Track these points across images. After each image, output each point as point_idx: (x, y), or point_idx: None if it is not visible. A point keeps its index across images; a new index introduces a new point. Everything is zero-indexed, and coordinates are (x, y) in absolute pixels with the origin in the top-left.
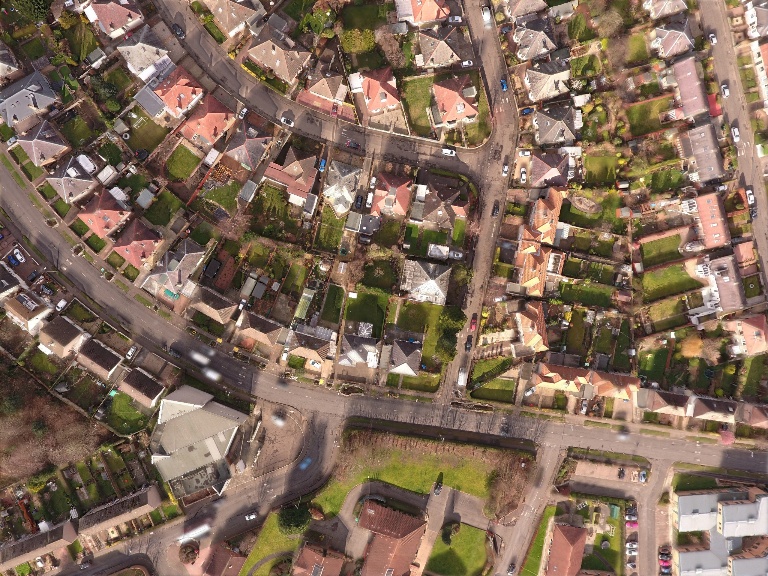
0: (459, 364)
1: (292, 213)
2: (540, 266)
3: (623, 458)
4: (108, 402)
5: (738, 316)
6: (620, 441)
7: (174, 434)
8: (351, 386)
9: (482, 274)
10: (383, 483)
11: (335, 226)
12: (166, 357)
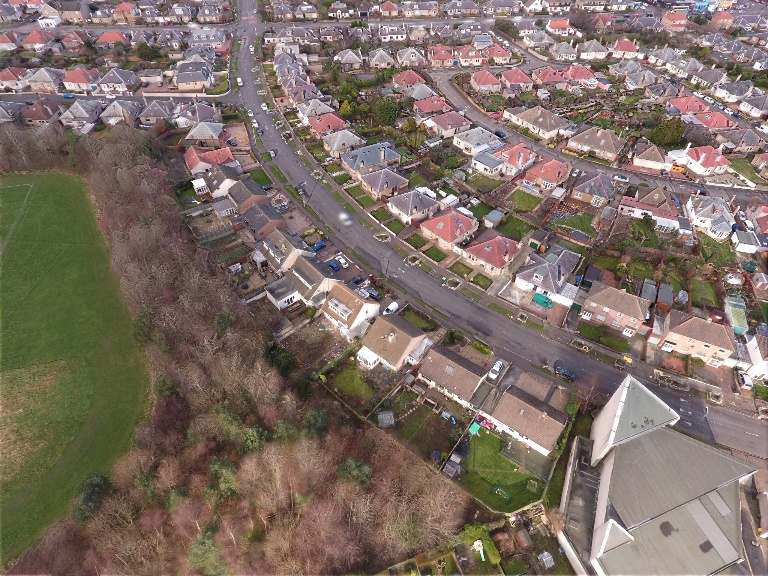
0: None
1: None
2: None
3: None
4: (464, 446)
5: None
6: None
7: (633, 481)
8: None
9: None
10: None
11: (721, 248)
12: (551, 379)
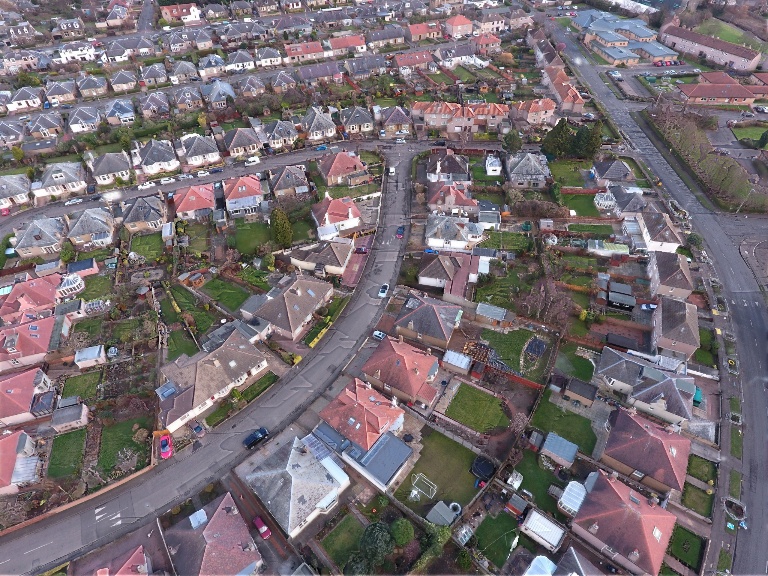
0: None
1: None
2: (484, 103)
3: (607, 81)
4: None
5: (475, 52)
6: (595, 83)
7: None
8: None
9: (501, 146)
10: None
11: (499, 238)
12: None
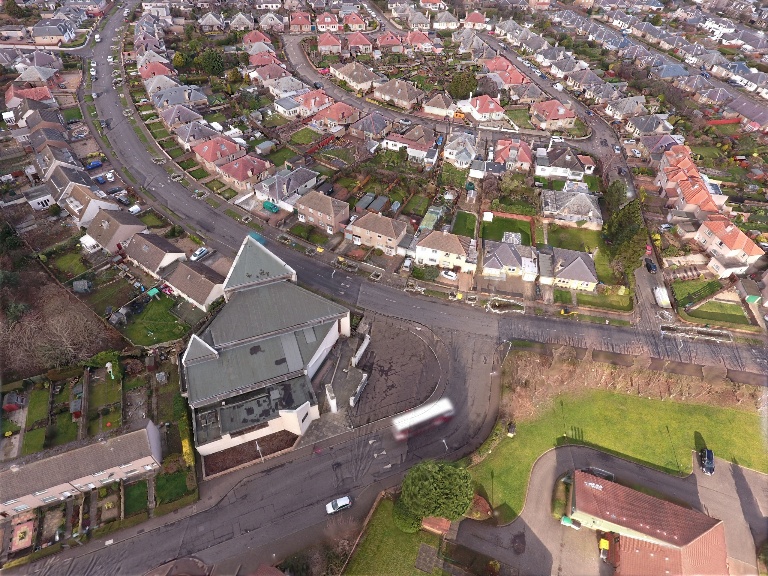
0: (648, 285)
1: (411, 166)
2: None
3: None
4: (139, 305)
5: None
6: None
7: (237, 316)
8: (504, 301)
9: None
10: (595, 449)
11: (457, 174)
12: None
